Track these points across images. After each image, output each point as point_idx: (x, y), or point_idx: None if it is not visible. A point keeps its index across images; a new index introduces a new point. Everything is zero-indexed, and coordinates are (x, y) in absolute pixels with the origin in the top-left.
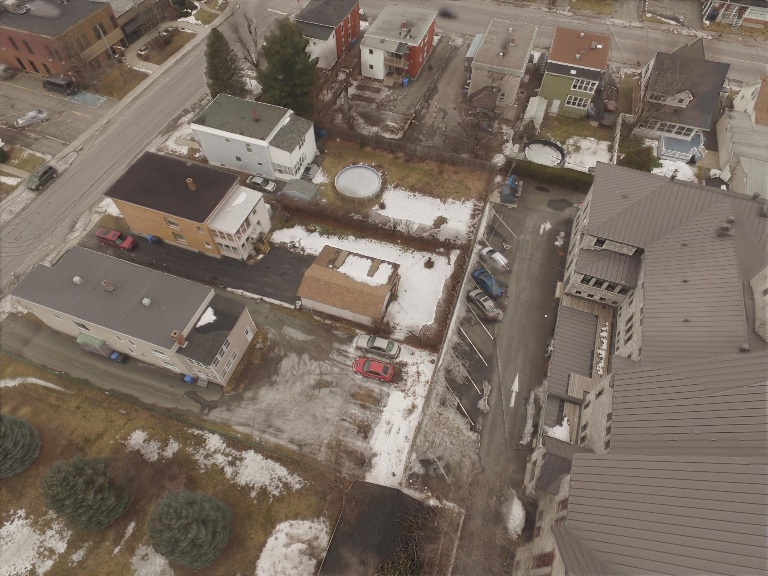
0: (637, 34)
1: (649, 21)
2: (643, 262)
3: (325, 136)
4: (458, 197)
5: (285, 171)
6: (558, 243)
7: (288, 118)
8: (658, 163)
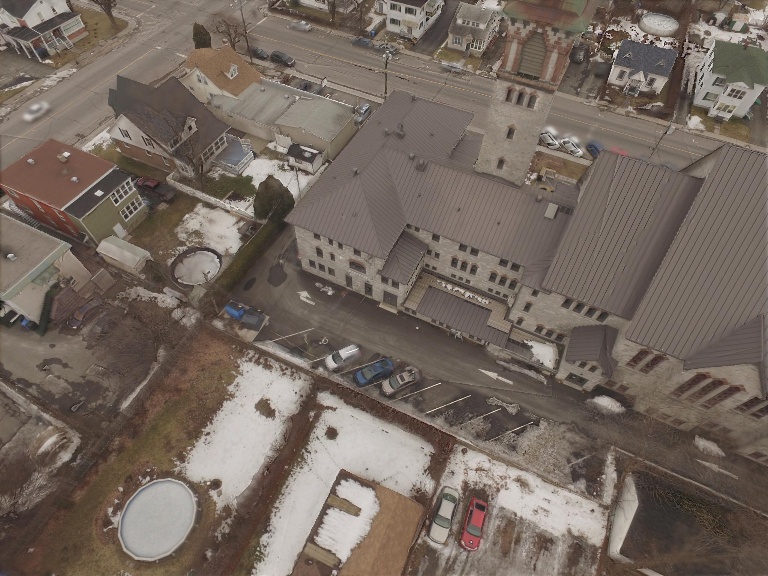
0: (24, 117)
1: (7, 99)
2: (411, 230)
3: None
4: (229, 378)
5: None
6: (330, 292)
7: None
8: (246, 178)
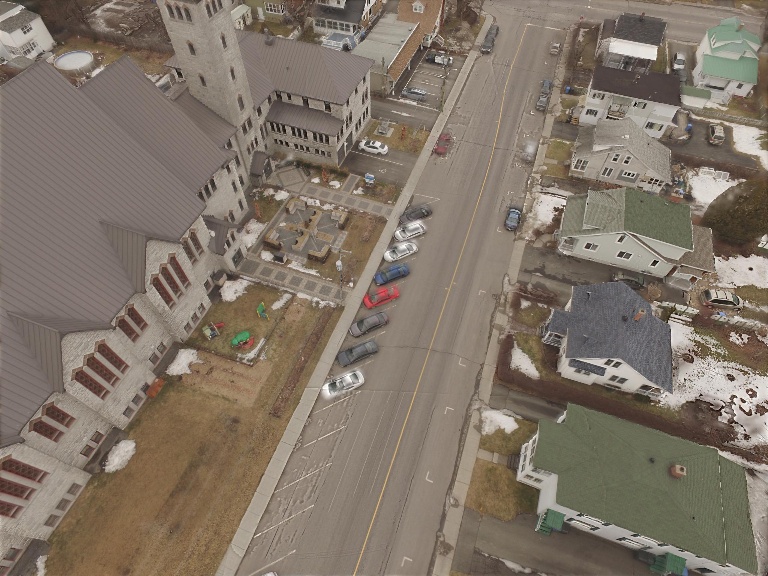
0: None
1: None
2: None
3: (66, 33)
4: (152, 73)
5: (16, 52)
6: None
7: (19, 11)
8: None
